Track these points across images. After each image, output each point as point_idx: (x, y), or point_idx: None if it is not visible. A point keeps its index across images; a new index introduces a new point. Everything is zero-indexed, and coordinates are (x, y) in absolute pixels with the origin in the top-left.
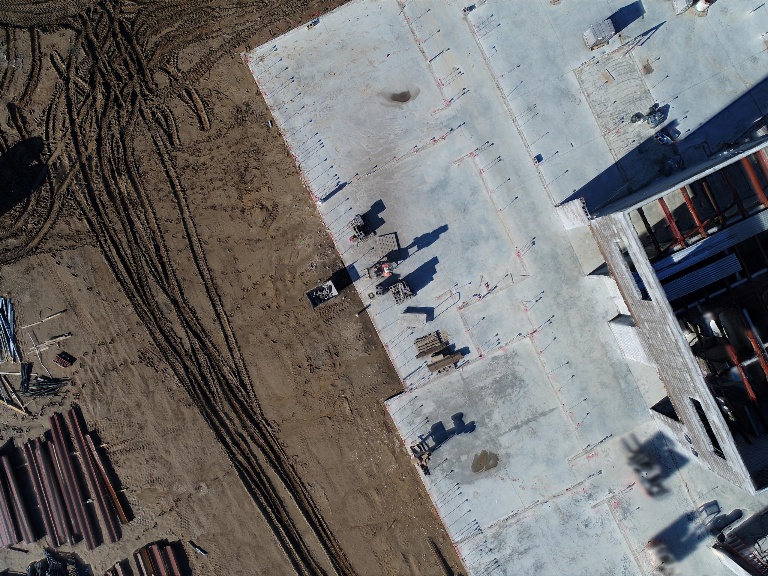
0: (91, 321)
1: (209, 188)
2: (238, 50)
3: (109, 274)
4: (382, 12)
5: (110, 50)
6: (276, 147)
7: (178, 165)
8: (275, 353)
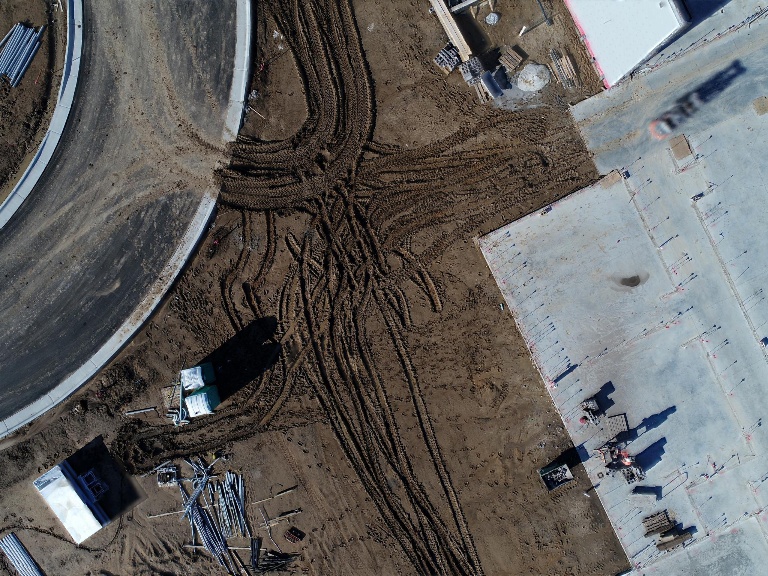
0: (321, 497)
1: (440, 367)
2: (471, 235)
3: (339, 450)
4: (613, 200)
5: (344, 233)
6: (507, 329)
7: (409, 345)
8: (503, 530)
